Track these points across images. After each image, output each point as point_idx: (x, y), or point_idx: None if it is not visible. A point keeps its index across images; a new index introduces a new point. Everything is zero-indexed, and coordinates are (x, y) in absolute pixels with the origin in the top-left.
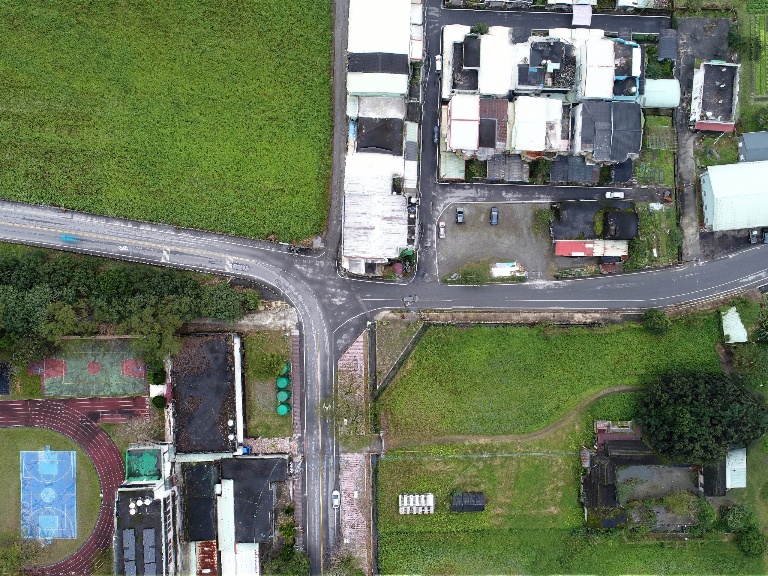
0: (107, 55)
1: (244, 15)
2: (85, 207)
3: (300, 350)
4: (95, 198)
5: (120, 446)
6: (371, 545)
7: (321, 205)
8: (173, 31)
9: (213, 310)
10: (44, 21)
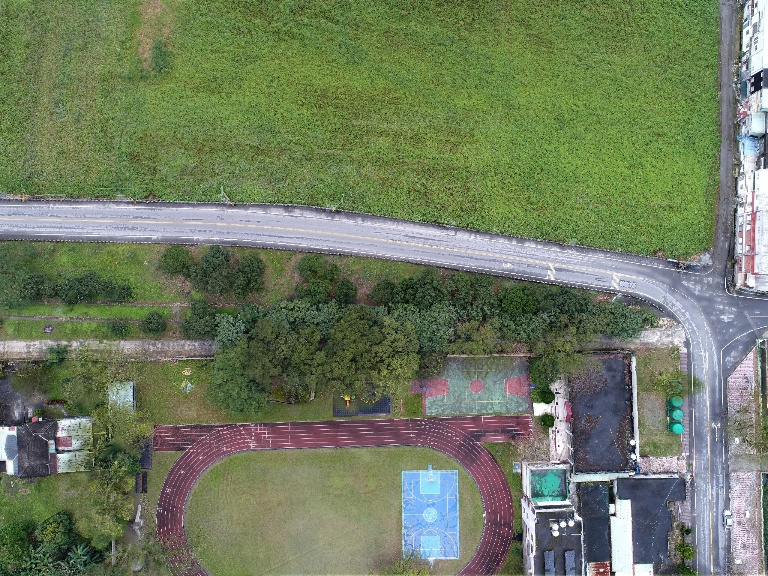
0: (490, 71)
1: (629, 31)
2: (469, 224)
3: (688, 368)
4: (479, 215)
5: (503, 465)
6: (763, 566)
7: (709, 221)
8: (557, 47)
9: (617, 328)
10: (425, 37)
